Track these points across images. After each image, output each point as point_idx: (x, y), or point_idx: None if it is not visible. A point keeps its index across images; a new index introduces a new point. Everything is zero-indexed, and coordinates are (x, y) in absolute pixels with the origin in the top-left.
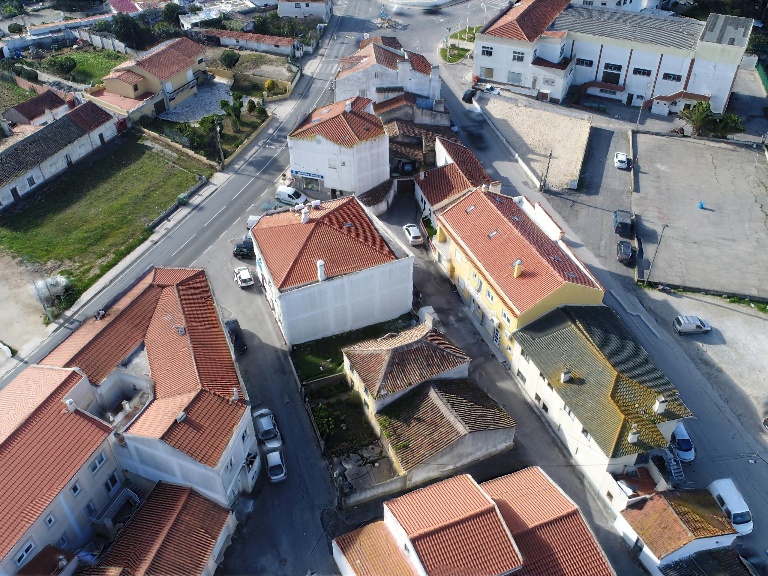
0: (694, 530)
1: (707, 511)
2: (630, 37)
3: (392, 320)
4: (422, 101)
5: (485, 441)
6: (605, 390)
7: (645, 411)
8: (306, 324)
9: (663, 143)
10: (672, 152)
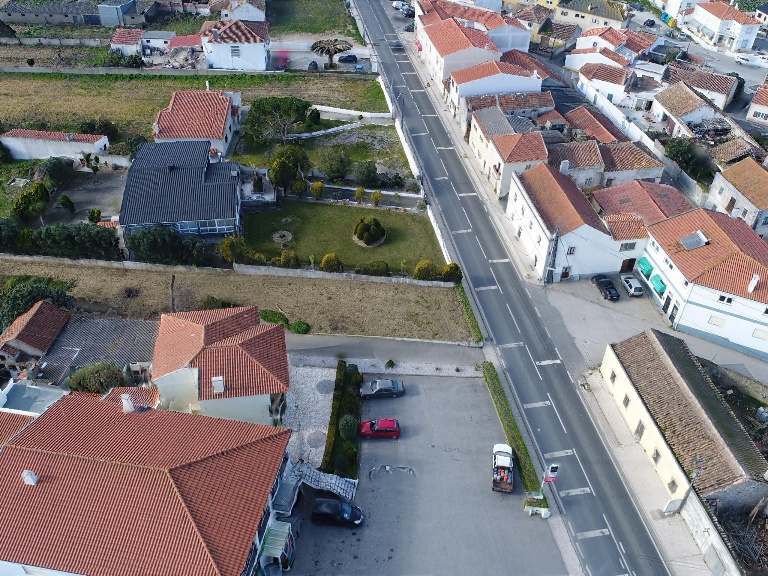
0: None
1: None
2: None
3: None
4: None
5: None
6: (607, 6)
7: None
8: None
9: None
10: None
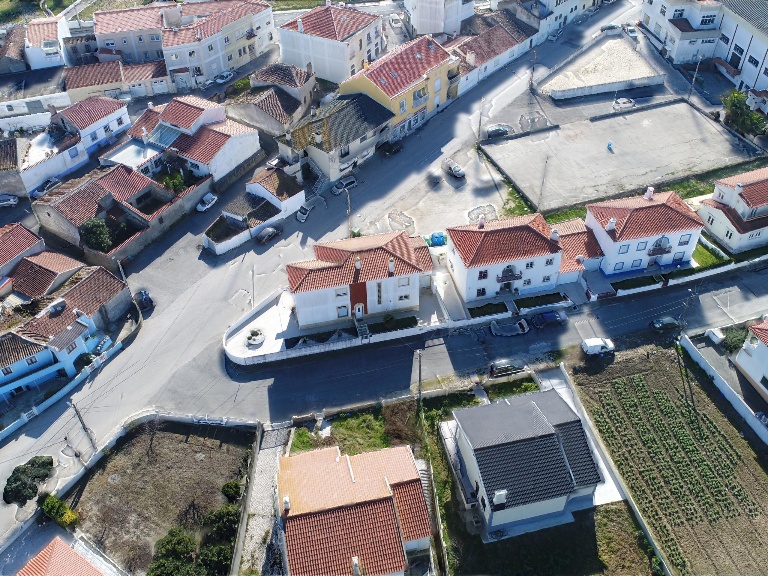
0: (265, 182)
1: (286, 189)
2: (765, 25)
3: (336, 83)
4: (541, 7)
5: (266, 119)
6: None
7: (313, 137)
8: (291, 56)
9: (688, 115)
10: (679, 121)
